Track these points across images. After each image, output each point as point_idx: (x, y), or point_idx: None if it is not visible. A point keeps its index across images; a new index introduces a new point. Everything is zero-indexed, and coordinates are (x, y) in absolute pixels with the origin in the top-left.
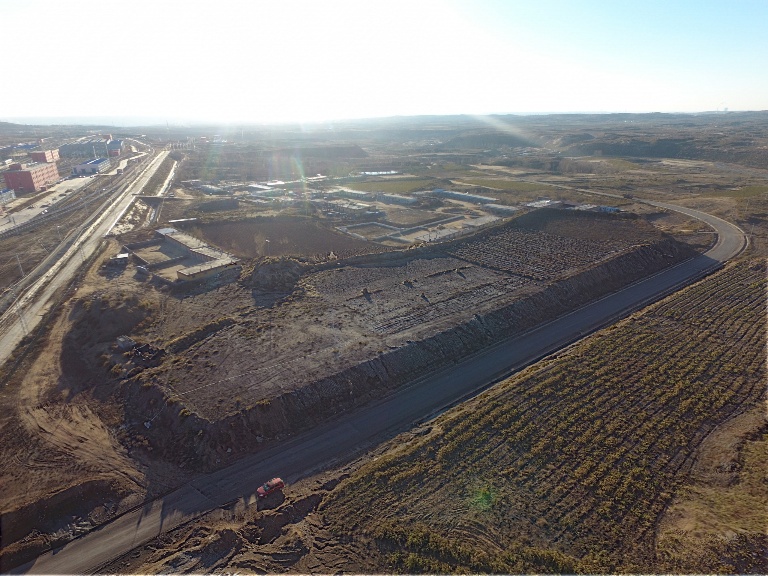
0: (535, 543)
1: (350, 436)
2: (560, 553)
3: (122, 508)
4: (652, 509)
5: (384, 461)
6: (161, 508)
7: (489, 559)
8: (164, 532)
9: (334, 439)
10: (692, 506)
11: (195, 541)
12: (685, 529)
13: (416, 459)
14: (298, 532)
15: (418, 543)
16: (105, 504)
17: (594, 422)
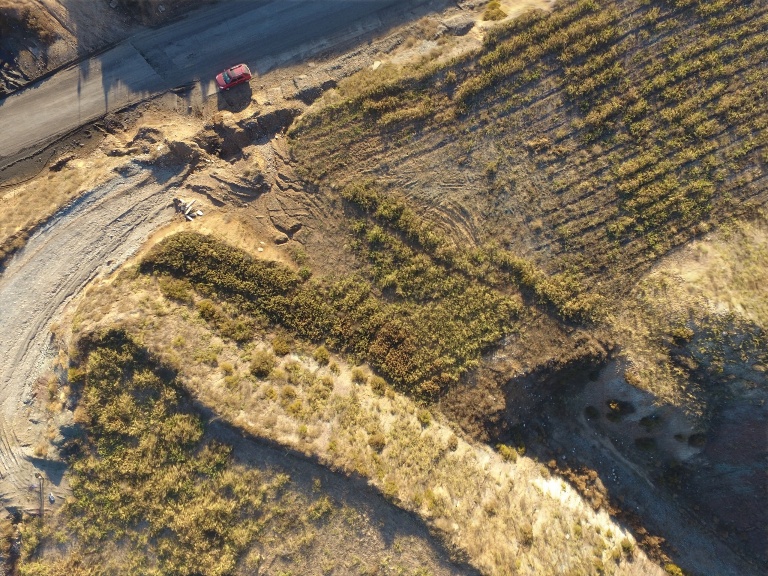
0: (514, 247)
1: (353, 1)
2: (533, 266)
3: (53, 61)
4: (673, 240)
5: (382, 83)
6: (101, 73)
7: (455, 253)
8: (111, 111)
9: (329, 1)
10: (720, 252)
11: (143, 147)
12: (685, 277)
13: (426, 90)
14: (260, 162)
15: (387, 217)
16: (29, 49)
17: (712, 85)
